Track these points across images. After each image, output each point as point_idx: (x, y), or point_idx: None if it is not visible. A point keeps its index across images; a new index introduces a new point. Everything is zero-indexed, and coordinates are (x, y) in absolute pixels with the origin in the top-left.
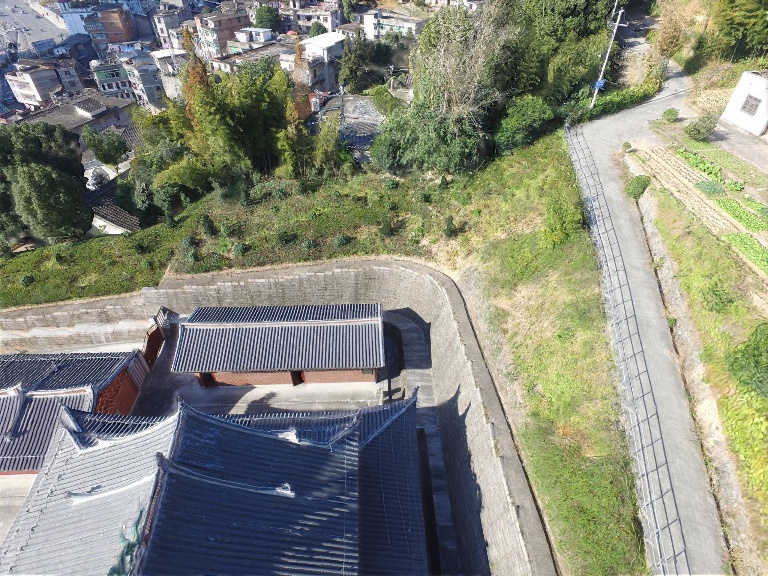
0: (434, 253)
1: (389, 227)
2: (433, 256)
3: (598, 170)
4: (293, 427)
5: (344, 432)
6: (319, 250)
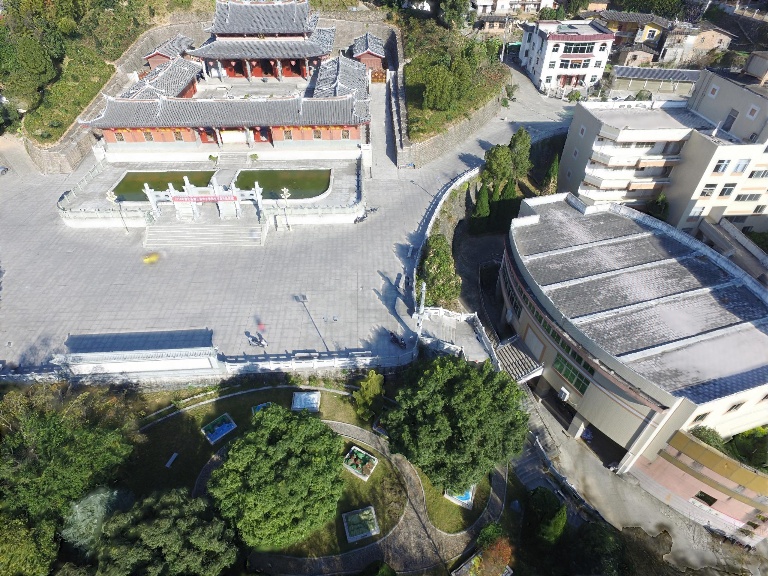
0: (154, 24)
1: None
2: (155, 24)
3: None
4: None
5: None
6: (133, 36)
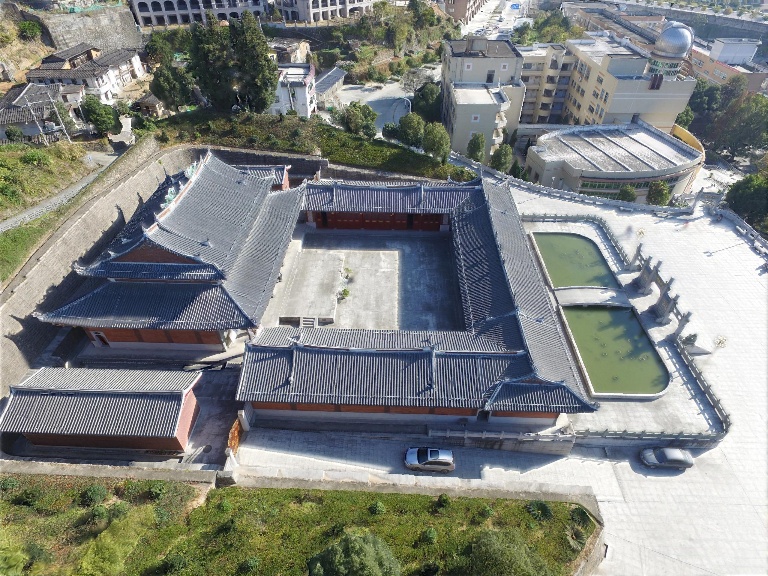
0: None
1: None
2: None
3: None
4: (124, 314)
5: (90, 267)
6: None
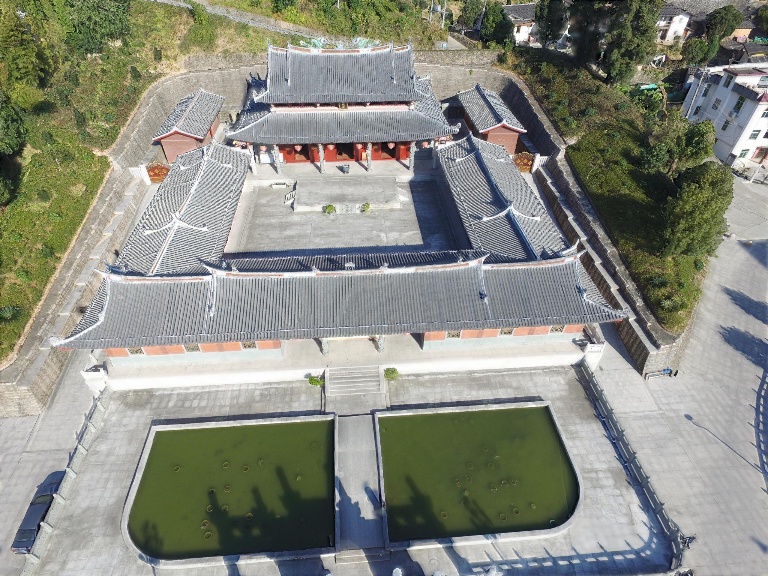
0: (162, 72)
1: (137, 71)
2: (164, 73)
3: (169, 2)
4: None
5: None
6: None
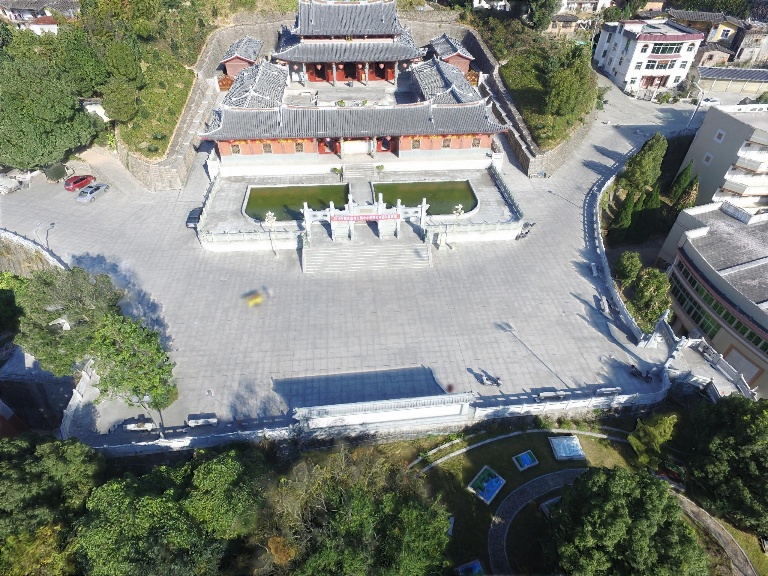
0: (218, 25)
1: None
2: (219, 26)
3: None
4: None
5: None
6: (202, 38)
